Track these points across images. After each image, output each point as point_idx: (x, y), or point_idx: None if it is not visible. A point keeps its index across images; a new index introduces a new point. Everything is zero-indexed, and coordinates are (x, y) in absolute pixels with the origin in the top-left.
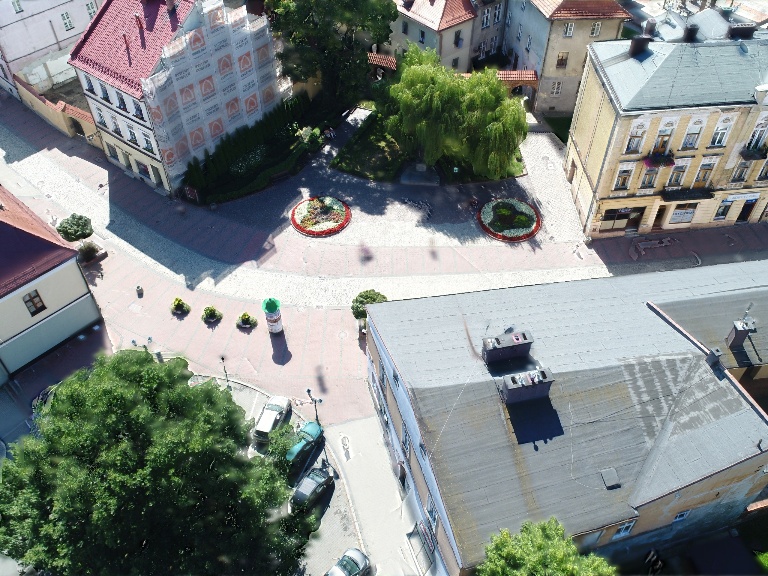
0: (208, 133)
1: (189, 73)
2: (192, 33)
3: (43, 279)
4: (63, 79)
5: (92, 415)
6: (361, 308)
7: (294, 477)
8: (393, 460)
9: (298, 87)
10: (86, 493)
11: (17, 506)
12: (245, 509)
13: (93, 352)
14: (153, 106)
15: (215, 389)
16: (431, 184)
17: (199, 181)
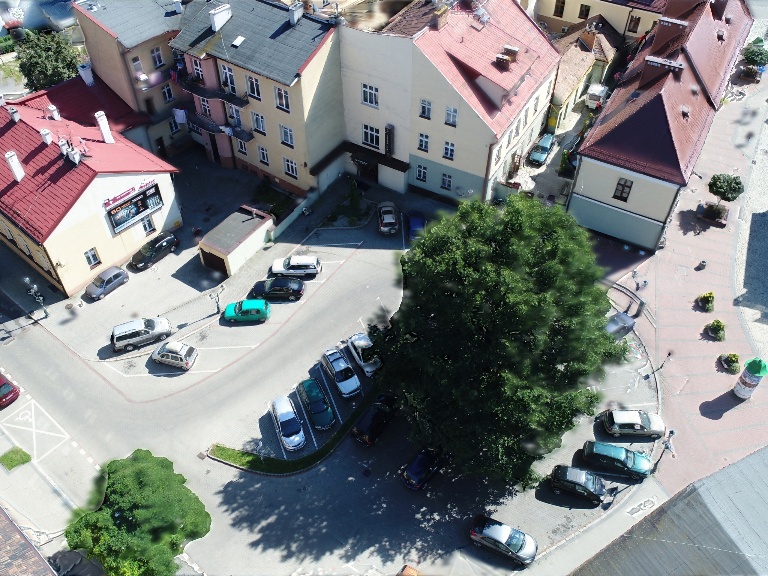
0: None
1: None
2: None
3: (644, 178)
4: None
5: (498, 216)
6: None
7: (584, 464)
8: None
9: None
10: (441, 246)
11: None
12: (496, 384)
13: (618, 261)
14: None
15: (624, 349)
16: None
17: None
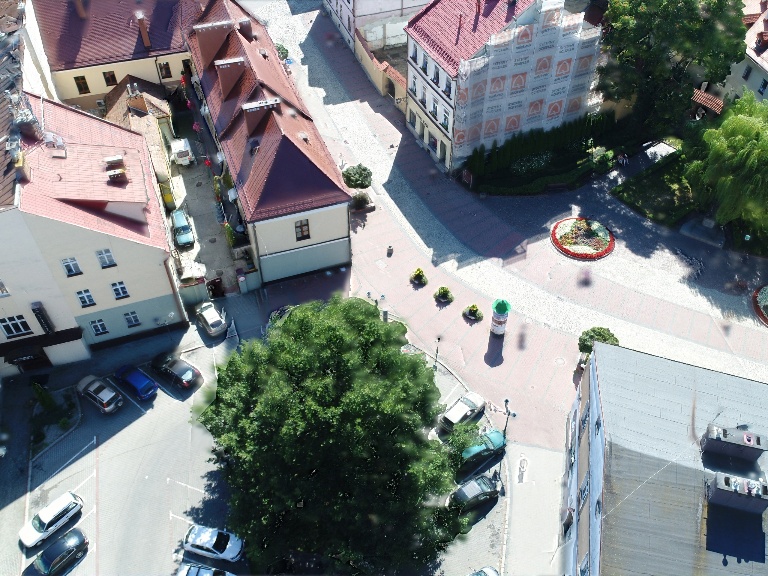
0: (503, 126)
1: (506, 65)
2: (523, 28)
3: (316, 212)
4: (395, 42)
5: (313, 343)
6: (589, 342)
7: (463, 475)
8: (564, 503)
9: (607, 105)
10: (284, 407)
11: (230, 394)
12: (408, 483)
13: (333, 289)
14: (463, 87)
15: (422, 363)
16: (713, 243)
17: (478, 168)
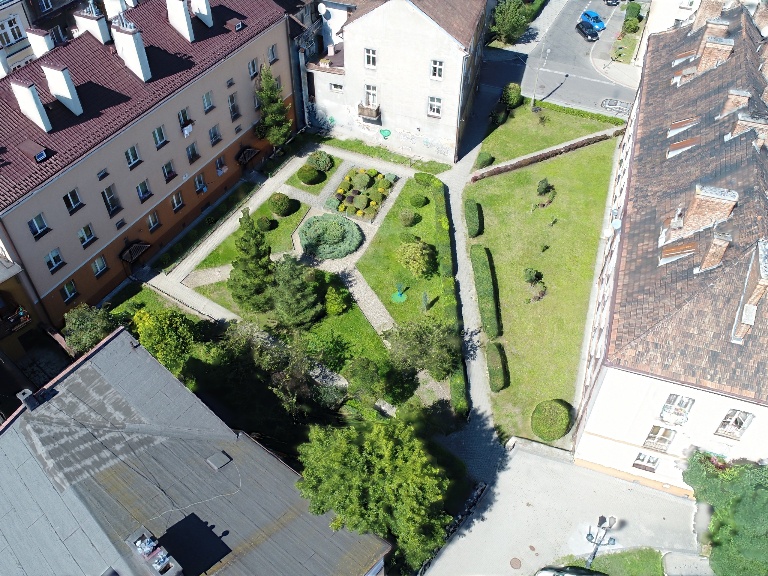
0: None
1: None
2: None
3: None
4: None
5: None
6: None
7: None
8: None
9: None
10: None
11: None
12: None
13: None
14: None
15: None
16: None
17: None
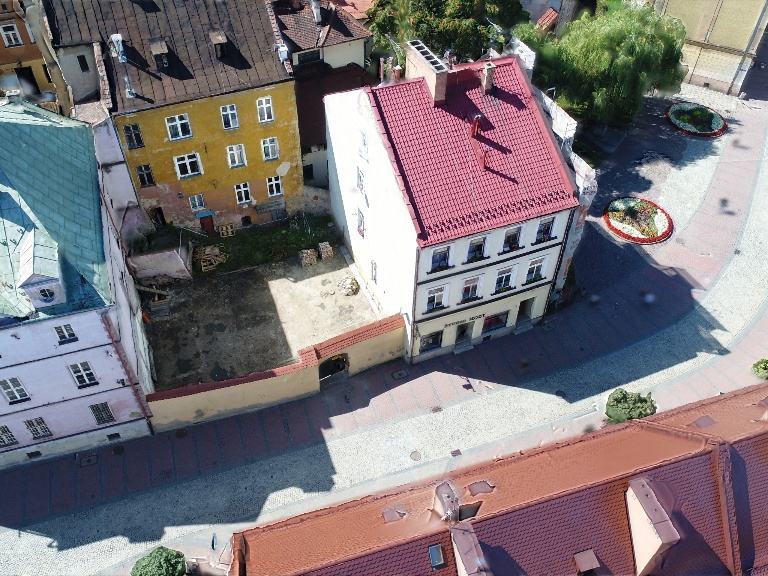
0: None
1: None
2: None
3: None
4: None
5: None
6: None
7: None
8: None
9: None
10: None
11: None
12: None
13: None
14: None
15: None
16: None
17: None
